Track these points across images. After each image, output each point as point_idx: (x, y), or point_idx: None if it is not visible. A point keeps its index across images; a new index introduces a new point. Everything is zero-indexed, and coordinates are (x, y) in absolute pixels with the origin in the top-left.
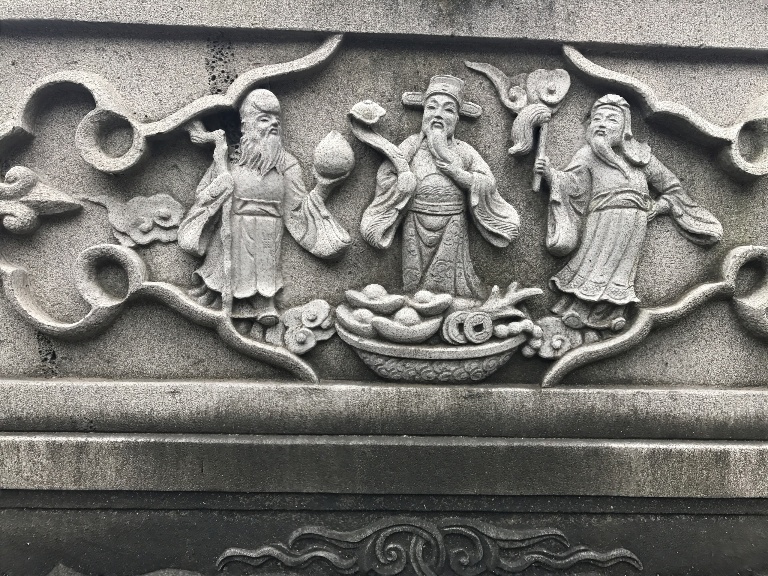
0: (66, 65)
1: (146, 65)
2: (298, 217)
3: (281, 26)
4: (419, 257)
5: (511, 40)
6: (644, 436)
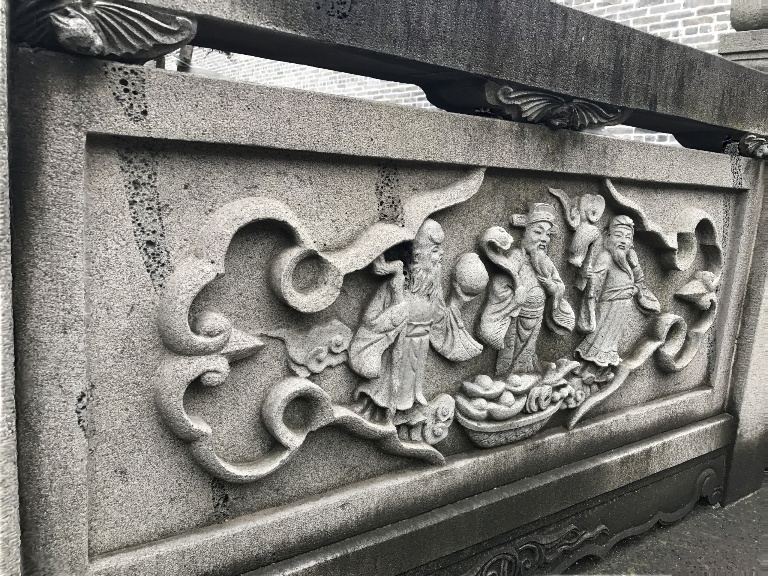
0: (245, 190)
1: (325, 191)
2: (439, 329)
3: (447, 160)
4: (514, 350)
5: (581, 174)
6: (612, 448)
